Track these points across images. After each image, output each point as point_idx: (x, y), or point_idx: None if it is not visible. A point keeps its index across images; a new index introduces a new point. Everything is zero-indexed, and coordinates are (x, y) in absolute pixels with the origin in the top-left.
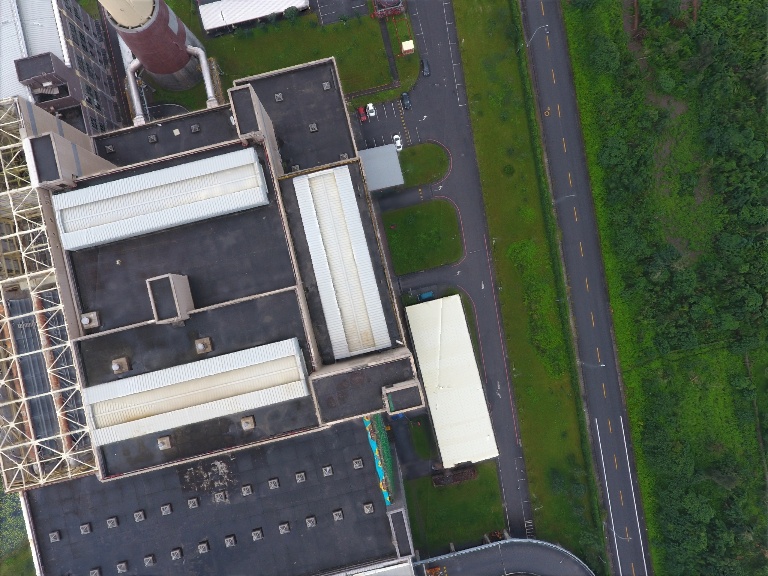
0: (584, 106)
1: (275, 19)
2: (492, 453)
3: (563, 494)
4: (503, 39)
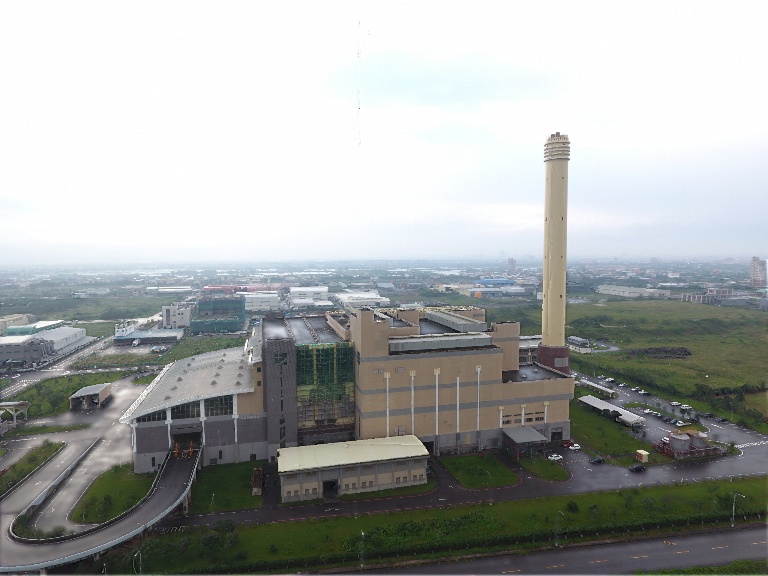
0: (707, 569)
1: (609, 416)
2: (283, 467)
3: (202, 550)
4: (717, 507)
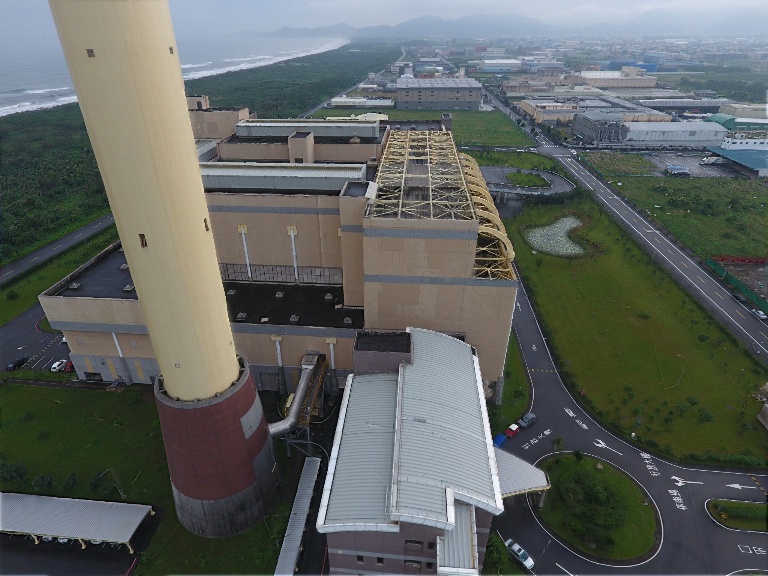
0: None
1: None
2: None
3: None
4: None
